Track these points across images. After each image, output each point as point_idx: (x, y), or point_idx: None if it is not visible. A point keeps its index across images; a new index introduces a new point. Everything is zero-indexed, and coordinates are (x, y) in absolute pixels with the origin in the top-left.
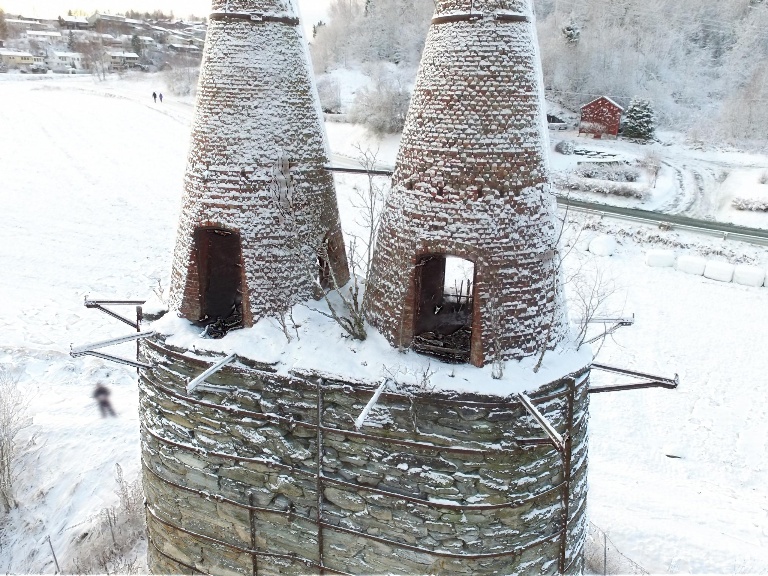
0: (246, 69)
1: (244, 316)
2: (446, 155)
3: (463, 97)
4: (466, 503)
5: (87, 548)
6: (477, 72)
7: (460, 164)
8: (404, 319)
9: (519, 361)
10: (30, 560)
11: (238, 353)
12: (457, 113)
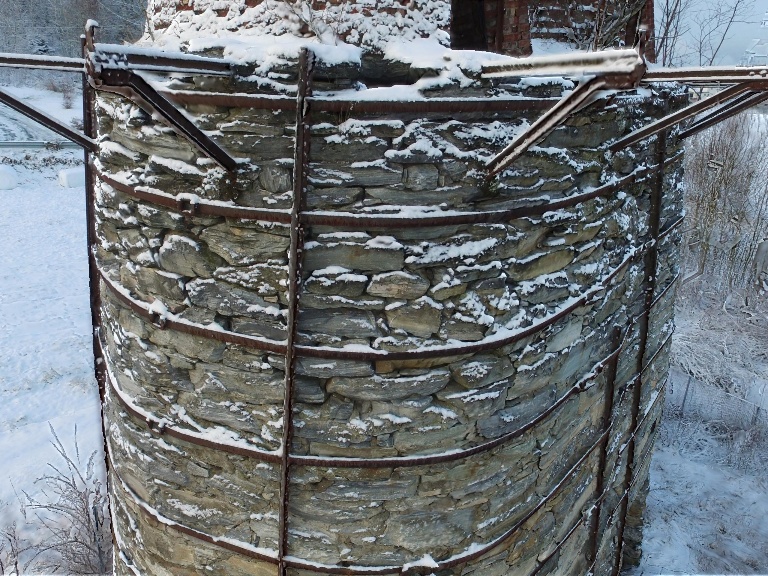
0: None
1: (505, 39)
2: None
3: None
4: None
5: None
6: None
7: None
8: None
9: None
10: None
11: None
12: None
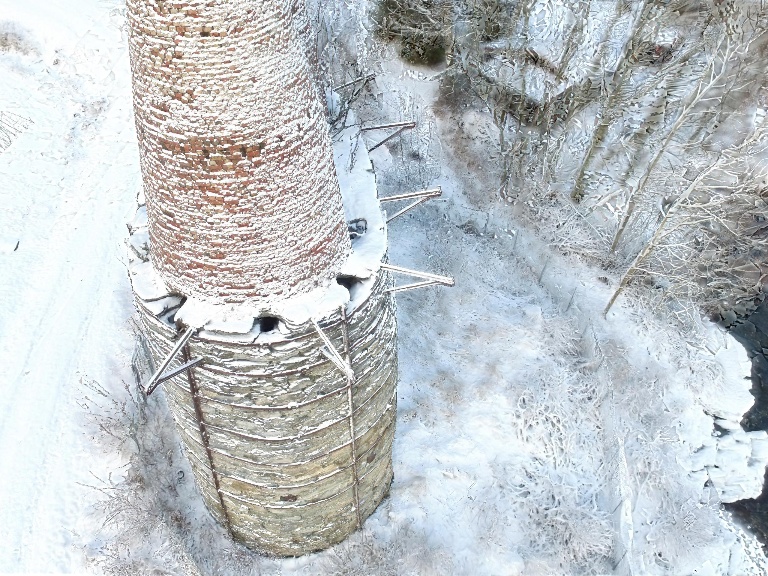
0: None
1: None
2: None
3: None
4: None
5: None
6: None
7: None
8: None
9: None
10: None
11: None
12: None
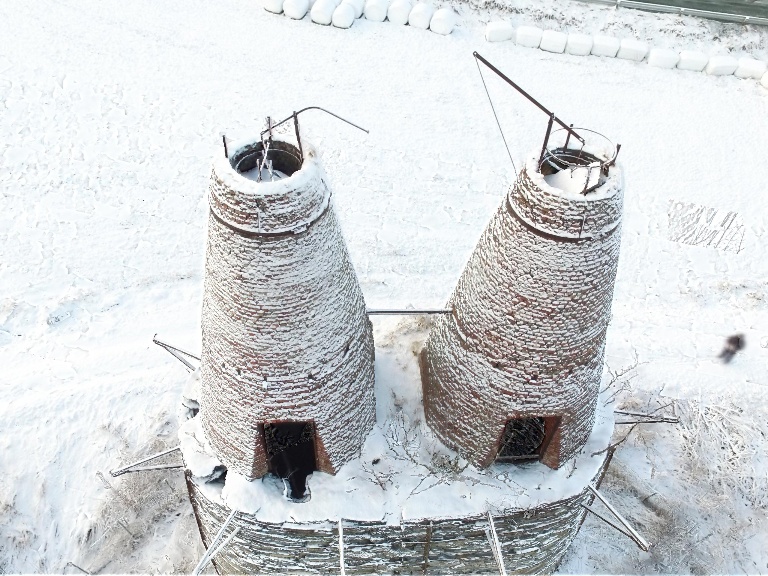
0: (298, 286)
1: (320, 465)
2: (543, 353)
3: (565, 310)
4: (542, 545)
5: (108, 550)
6: (581, 289)
7: (556, 359)
8: (490, 454)
9: (580, 453)
10: (43, 569)
11: (344, 518)
12: (558, 323)
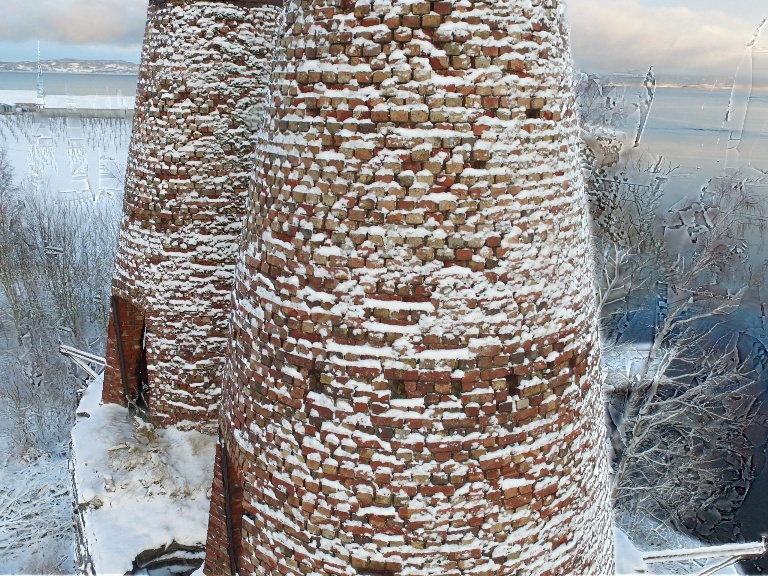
0: None
1: None
2: None
3: None
4: None
5: None
6: None
7: None
8: None
9: None
10: None
11: None
12: None
